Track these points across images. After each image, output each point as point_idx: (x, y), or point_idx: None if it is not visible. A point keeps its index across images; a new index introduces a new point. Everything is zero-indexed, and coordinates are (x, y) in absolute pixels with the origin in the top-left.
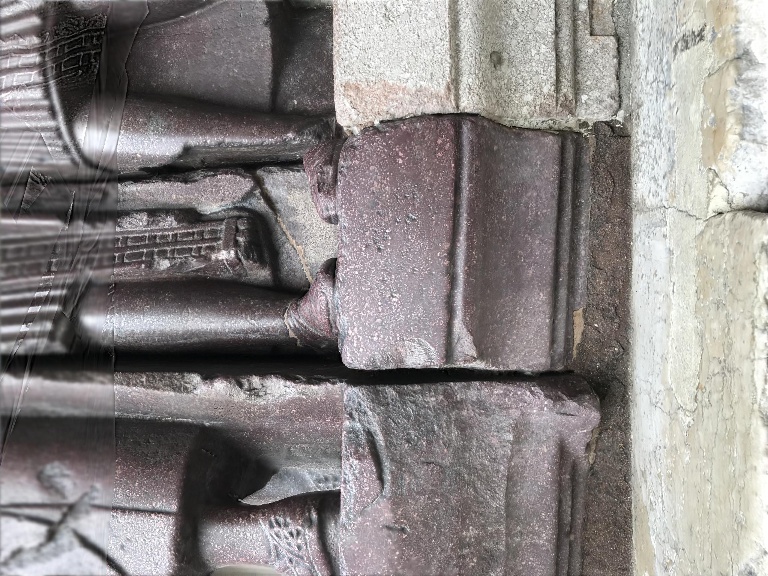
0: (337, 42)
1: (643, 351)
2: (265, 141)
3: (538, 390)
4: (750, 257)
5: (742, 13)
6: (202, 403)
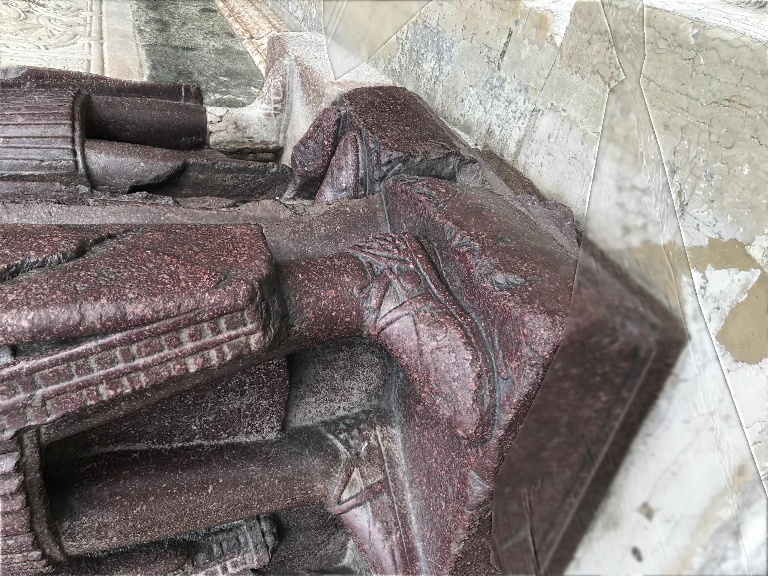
0: (319, 76)
1: (569, 181)
2: (251, 165)
3: (523, 194)
4: (587, 2)
5: (524, 2)
6: (246, 222)
